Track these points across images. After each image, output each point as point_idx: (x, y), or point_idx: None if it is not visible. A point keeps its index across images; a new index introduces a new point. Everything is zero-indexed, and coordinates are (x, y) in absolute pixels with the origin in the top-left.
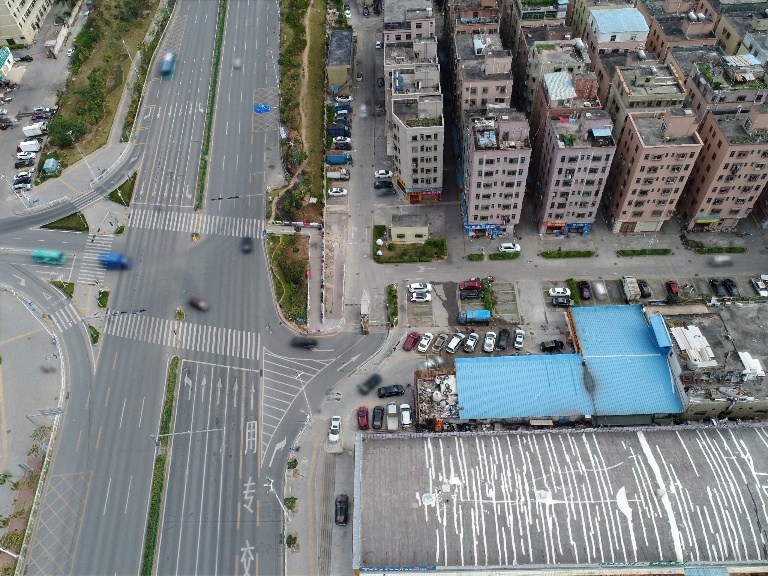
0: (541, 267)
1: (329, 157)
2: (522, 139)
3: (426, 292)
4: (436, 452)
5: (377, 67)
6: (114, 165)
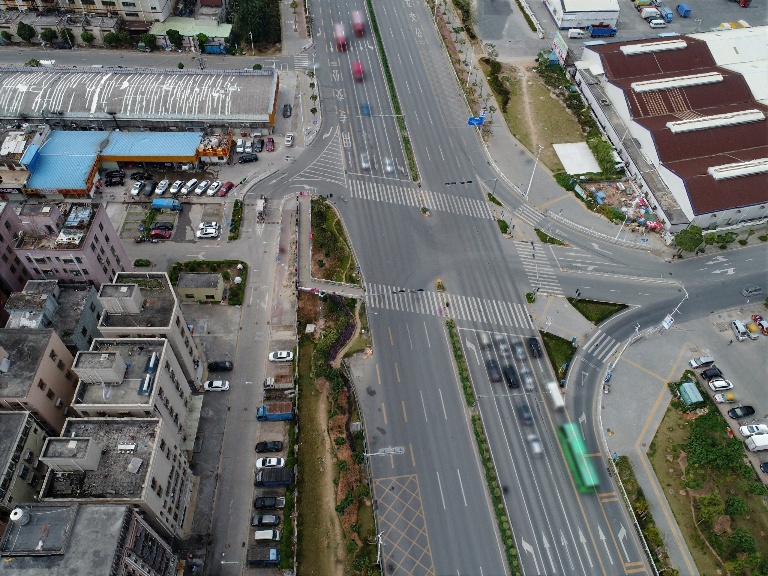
0: None
1: None
2: None
3: None
4: (223, 109)
5: None
6: None
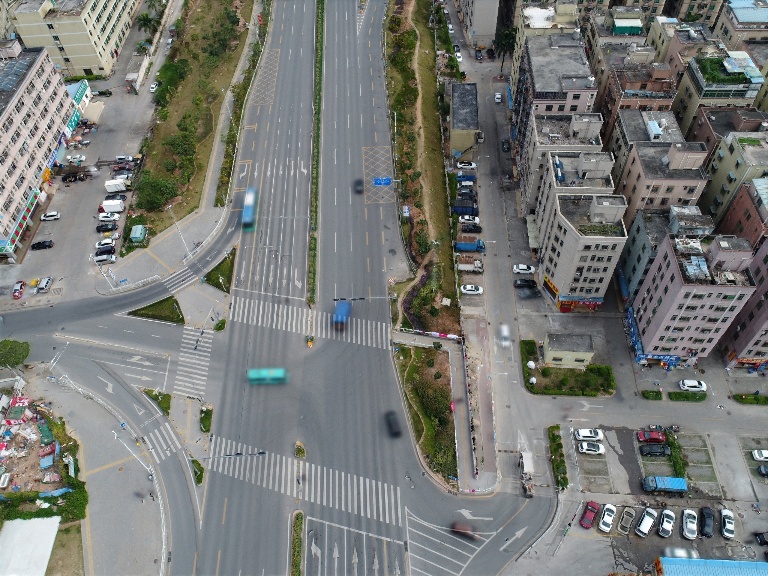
0: (736, 416)
1: (459, 244)
2: (739, 269)
3: (596, 441)
4: None
5: (499, 126)
6: (210, 237)
